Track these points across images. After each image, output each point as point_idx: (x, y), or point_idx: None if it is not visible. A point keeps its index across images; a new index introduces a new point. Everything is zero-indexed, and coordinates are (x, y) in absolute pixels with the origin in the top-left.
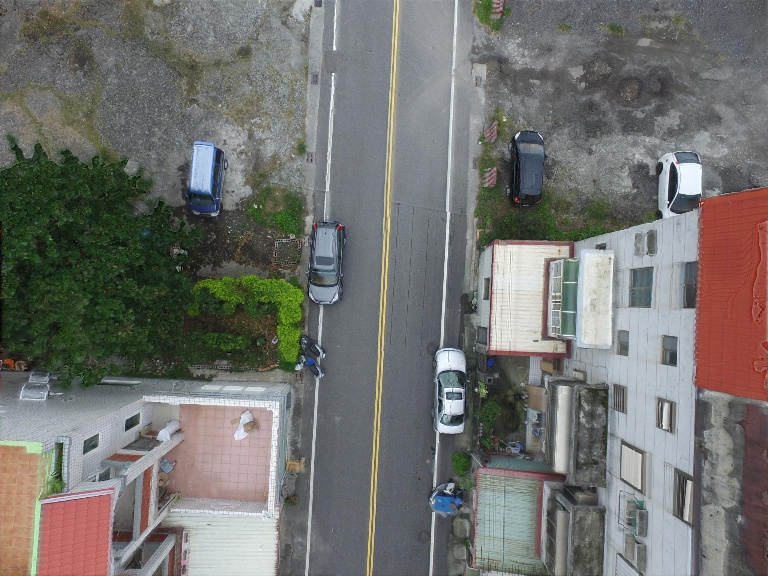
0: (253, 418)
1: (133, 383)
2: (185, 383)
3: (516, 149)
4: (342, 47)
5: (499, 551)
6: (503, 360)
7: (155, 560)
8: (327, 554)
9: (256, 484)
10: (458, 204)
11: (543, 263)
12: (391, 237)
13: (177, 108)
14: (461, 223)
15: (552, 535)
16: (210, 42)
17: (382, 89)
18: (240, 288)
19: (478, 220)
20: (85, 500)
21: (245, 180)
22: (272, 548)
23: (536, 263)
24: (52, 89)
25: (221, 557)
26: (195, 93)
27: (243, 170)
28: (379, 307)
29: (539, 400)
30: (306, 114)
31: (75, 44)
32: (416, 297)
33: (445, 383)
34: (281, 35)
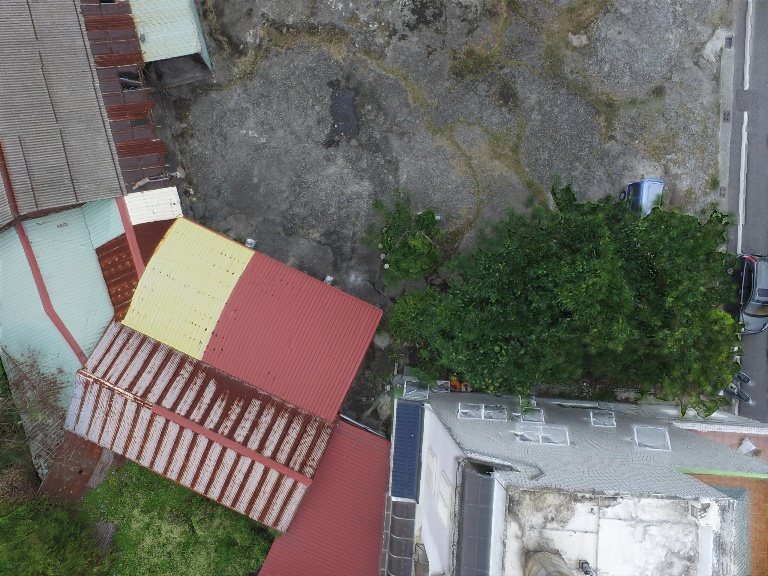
0: None
1: (590, 406)
2: (621, 406)
3: None
4: (753, 87)
5: None
6: None
7: None
8: None
9: None
10: None
11: None
12: None
13: (597, 144)
14: None
15: None
16: (626, 81)
17: None
18: None
19: None
20: None
21: None
22: None
23: None
24: (480, 125)
25: None
26: (613, 129)
27: None
28: None
29: None
30: (718, 150)
31: (500, 82)
32: None
33: None
34: (693, 75)
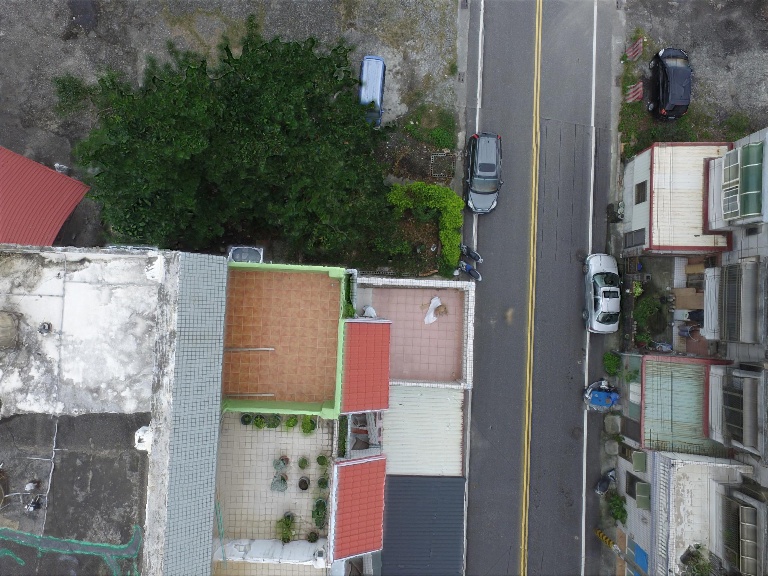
0: (442, 303)
1: None
2: None
3: (662, 64)
4: None
5: (668, 433)
6: (649, 266)
7: (373, 422)
8: (486, 450)
9: (445, 365)
10: (603, 120)
11: (702, 163)
12: (541, 151)
13: (336, 32)
14: (606, 137)
15: (734, 405)
16: None
17: (529, 12)
18: (408, 194)
19: (622, 134)
20: (373, 325)
21: (401, 98)
22: (458, 427)
23: (696, 163)
24: (219, 15)
25: (412, 435)
26: (352, 18)
27: (399, 89)
28: (531, 216)
29: (689, 300)
30: (457, 36)
31: None
32: (565, 207)
33: (601, 284)
34: None
